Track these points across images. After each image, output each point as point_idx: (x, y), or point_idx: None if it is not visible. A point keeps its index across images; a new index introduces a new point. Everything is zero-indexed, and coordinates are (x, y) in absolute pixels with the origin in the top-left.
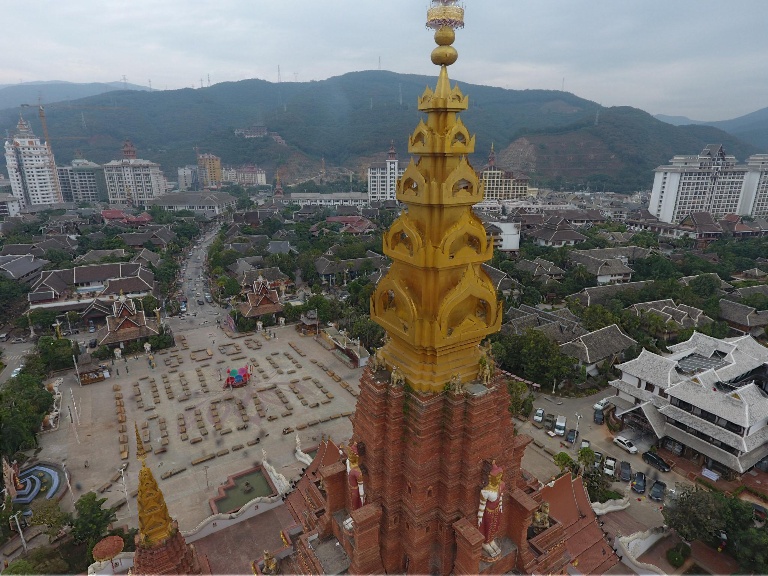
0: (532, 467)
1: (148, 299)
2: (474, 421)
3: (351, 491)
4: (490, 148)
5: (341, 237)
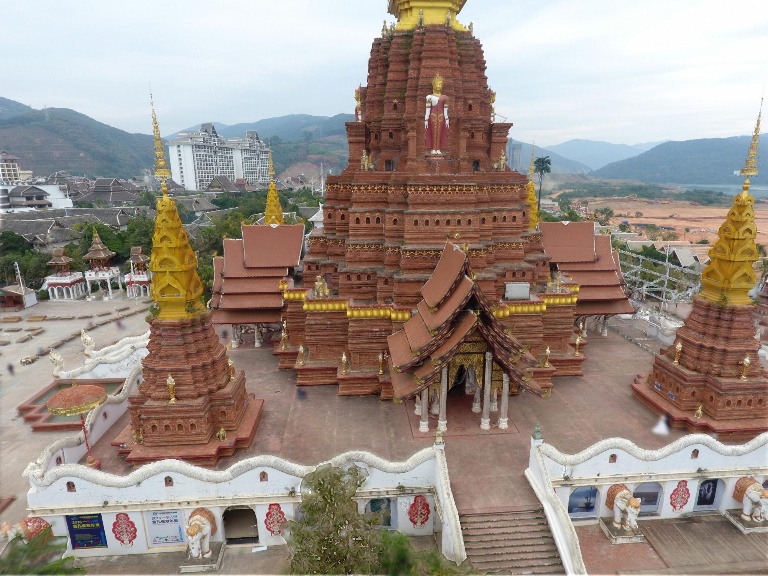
0: None
1: None
2: None
3: (438, 120)
4: None
5: None
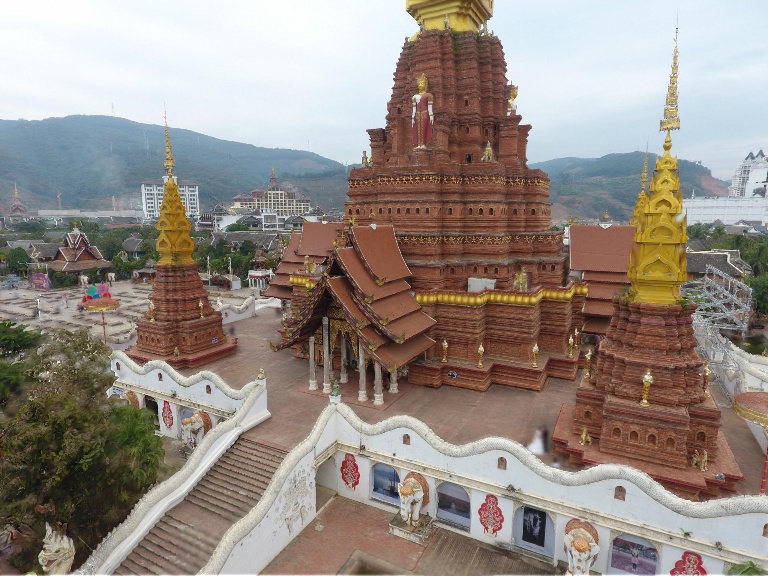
0: None
1: None
2: (499, 52)
3: (421, 117)
4: (271, 170)
5: (141, 227)
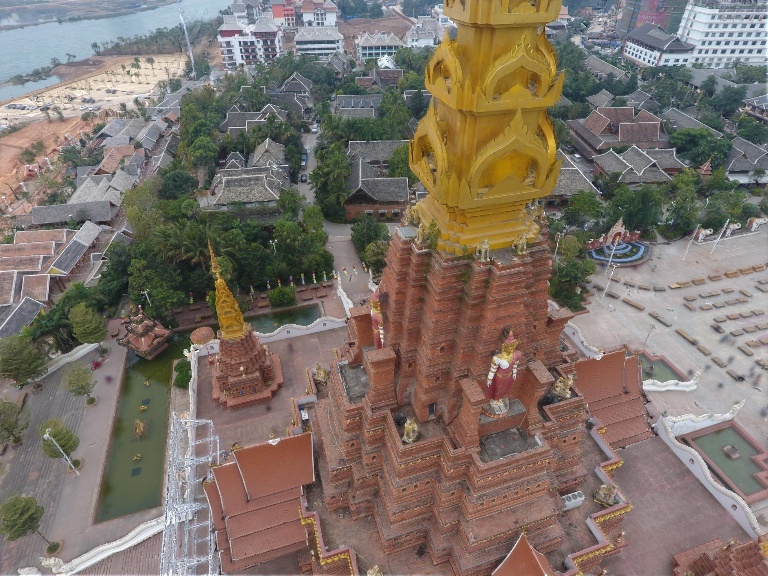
0: None
1: None
2: None
3: None
4: None
5: None
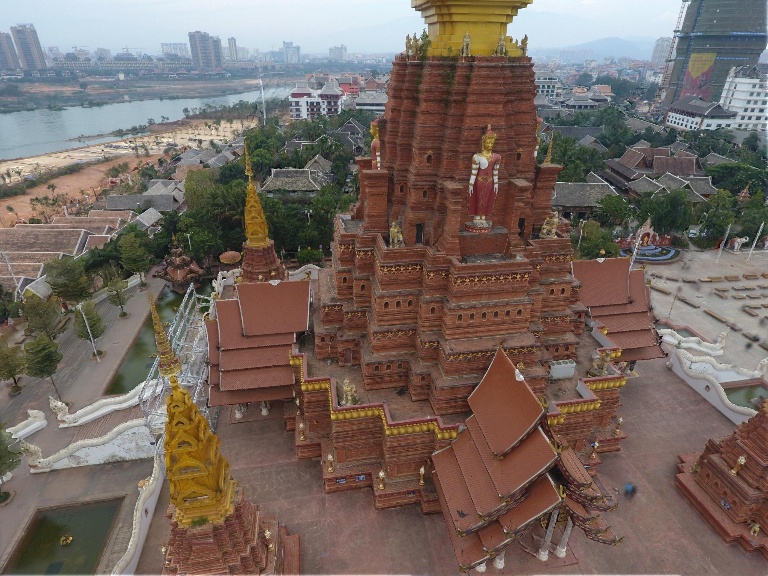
0: None
1: None
2: None
3: None
4: None
5: None
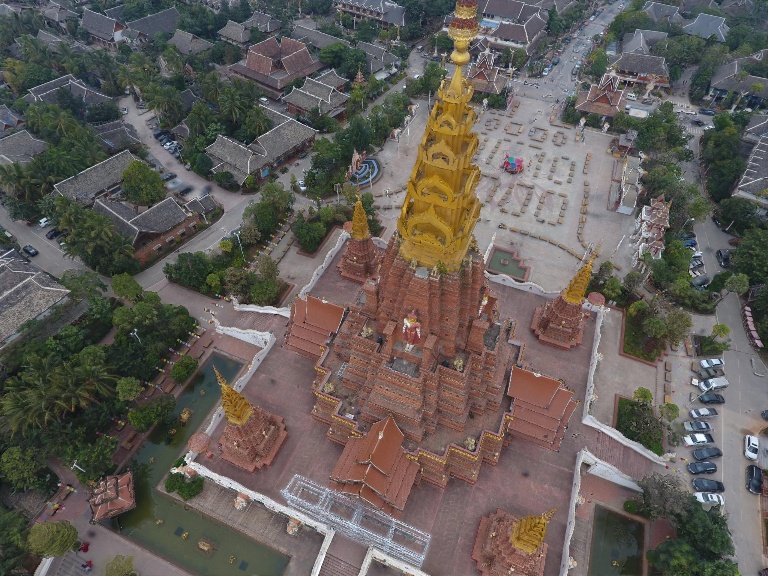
0: (633, 382)
1: (519, 53)
2: (410, 286)
3: None
4: None
5: None
